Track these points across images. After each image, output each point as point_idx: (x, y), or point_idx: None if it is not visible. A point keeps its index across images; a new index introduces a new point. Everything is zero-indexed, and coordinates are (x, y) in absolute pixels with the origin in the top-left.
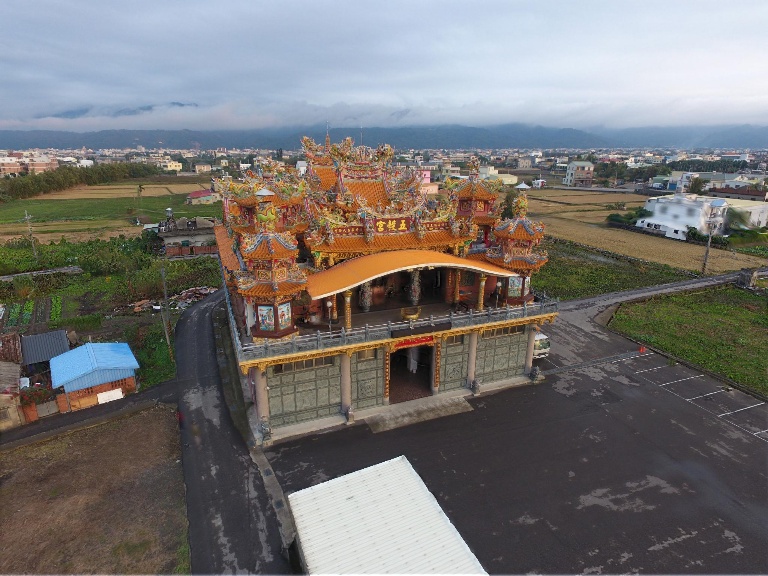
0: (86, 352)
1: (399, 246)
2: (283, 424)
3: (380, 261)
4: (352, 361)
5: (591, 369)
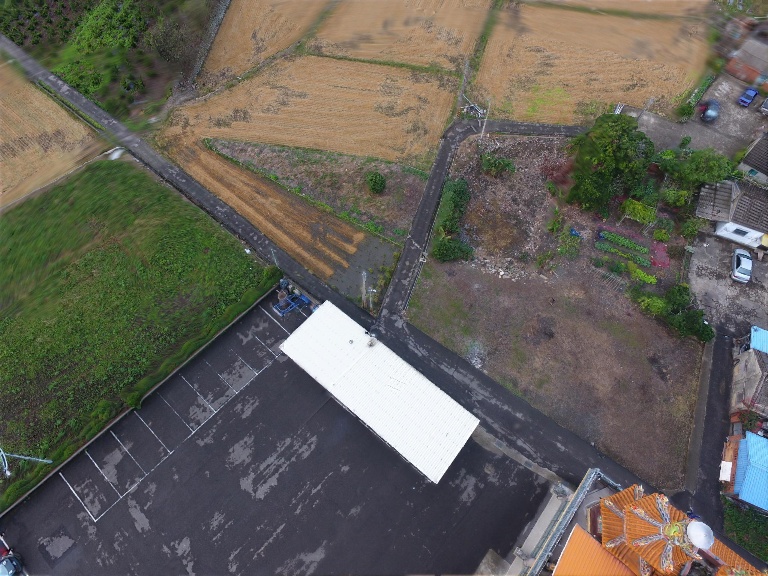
0: None
1: None
2: None
3: None
4: None
5: None
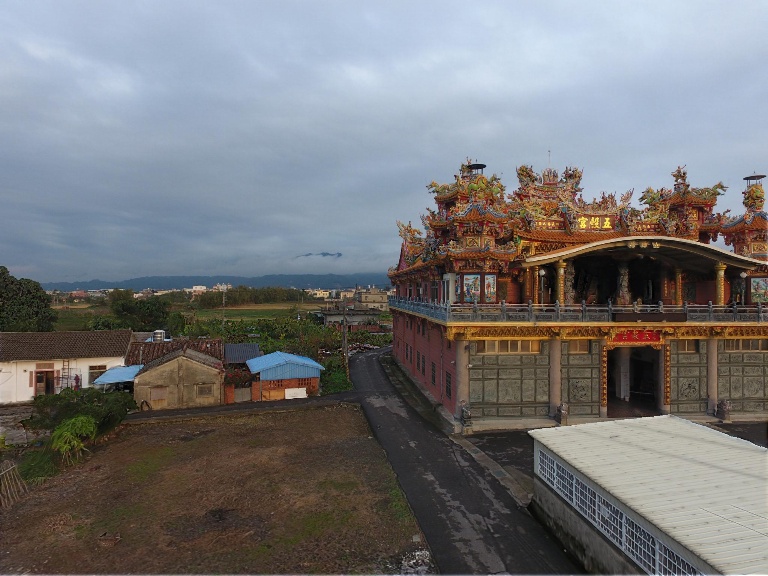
0: (278, 355)
1: None
2: (482, 417)
3: None
4: (562, 351)
5: None
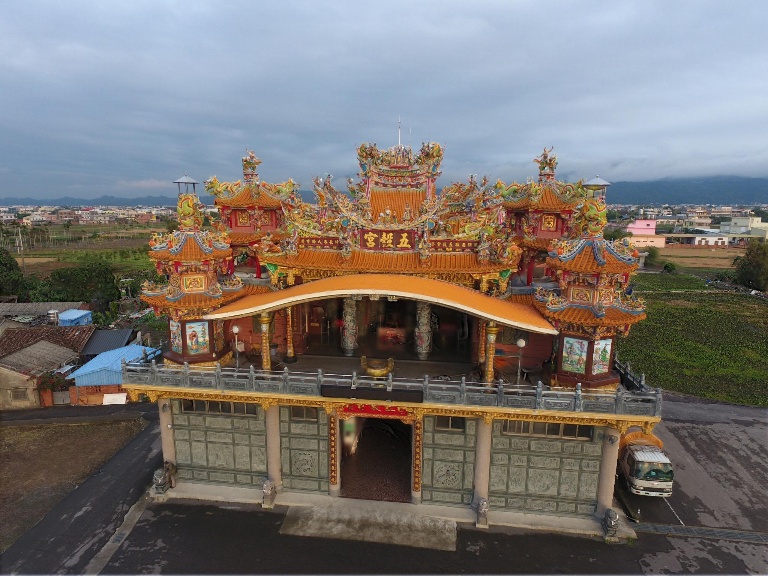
0: (121, 352)
1: (385, 268)
2: (192, 479)
3: (331, 282)
4: (282, 418)
5: (760, 551)
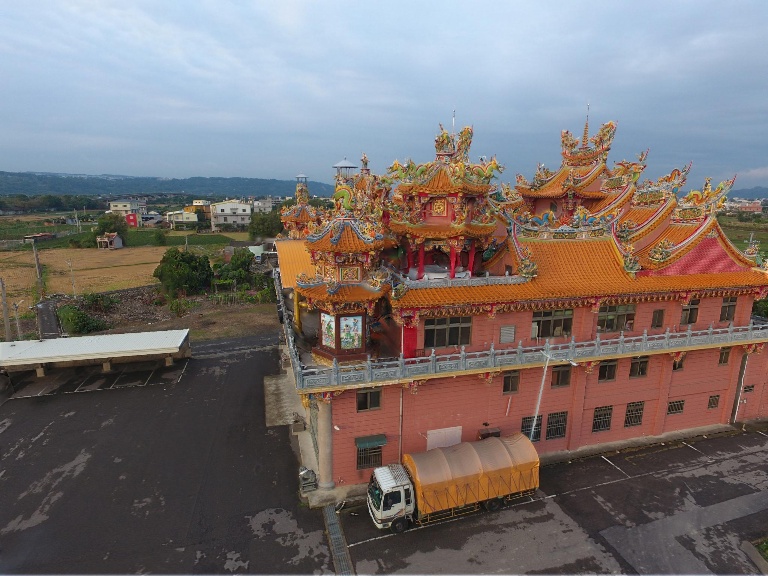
0: None
1: None
2: None
3: None
4: None
5: None
